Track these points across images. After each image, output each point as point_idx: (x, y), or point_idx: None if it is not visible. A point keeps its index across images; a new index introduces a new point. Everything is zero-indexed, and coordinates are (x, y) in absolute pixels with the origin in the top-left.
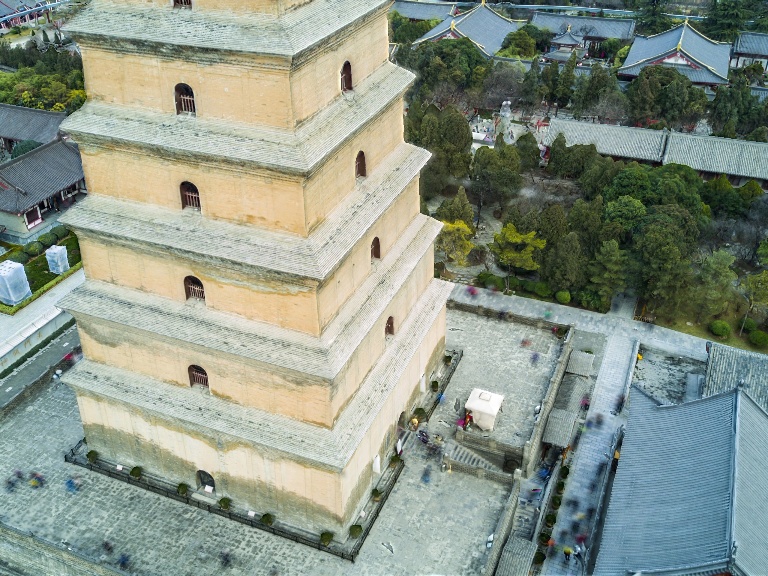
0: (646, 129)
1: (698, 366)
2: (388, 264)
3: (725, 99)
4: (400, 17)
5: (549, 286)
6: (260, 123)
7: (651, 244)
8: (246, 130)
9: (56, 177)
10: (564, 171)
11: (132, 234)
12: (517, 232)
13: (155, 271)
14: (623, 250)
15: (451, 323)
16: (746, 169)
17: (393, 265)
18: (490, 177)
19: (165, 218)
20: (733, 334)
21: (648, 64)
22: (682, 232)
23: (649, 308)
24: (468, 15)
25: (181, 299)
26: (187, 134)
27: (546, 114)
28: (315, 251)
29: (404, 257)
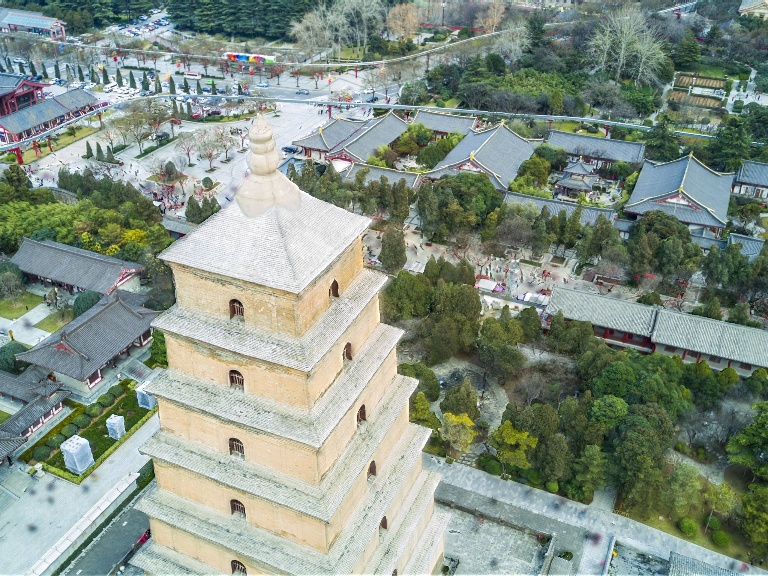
0: (638, 304)
1: (665, 565)
2: (393, 532)
3: (716, 260)
4: (425, 130)
5: (540, 476)
6: (293, 475)
7: (628, 452)
8: (283, 479)
9: (114, 339)
10: (562, 346)
11: (192, 530)
12: (513, 427)
13: (209, 551)
14: (604, 453)
15: (451, 524)
16: (726, 350)
17: (397, 531)
18: (495, 353)
19: (218, 519)
20: (699, 530)
21: (652, 202)
22: (657, 438)
23: (626, 505)
24: (487, 140)
25: (228, 572)
26: (238, 474)
27: (555, 251)
28: (333, 565)
29: (407, 520)
